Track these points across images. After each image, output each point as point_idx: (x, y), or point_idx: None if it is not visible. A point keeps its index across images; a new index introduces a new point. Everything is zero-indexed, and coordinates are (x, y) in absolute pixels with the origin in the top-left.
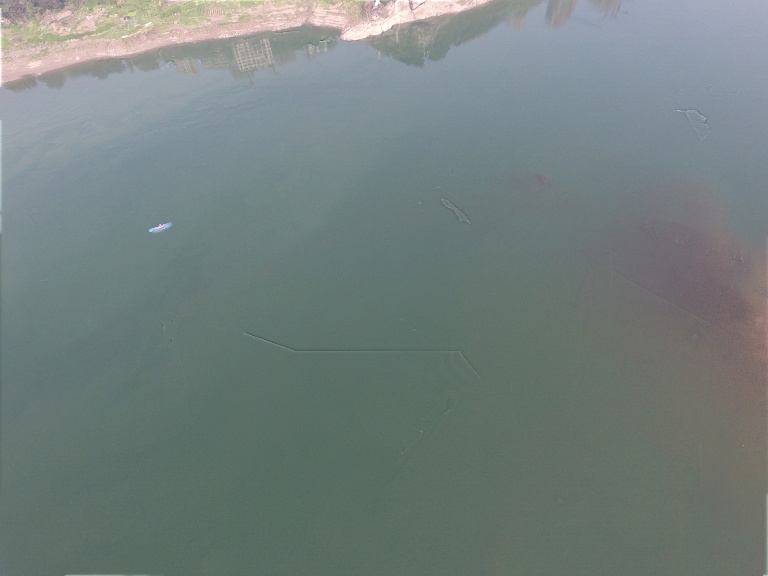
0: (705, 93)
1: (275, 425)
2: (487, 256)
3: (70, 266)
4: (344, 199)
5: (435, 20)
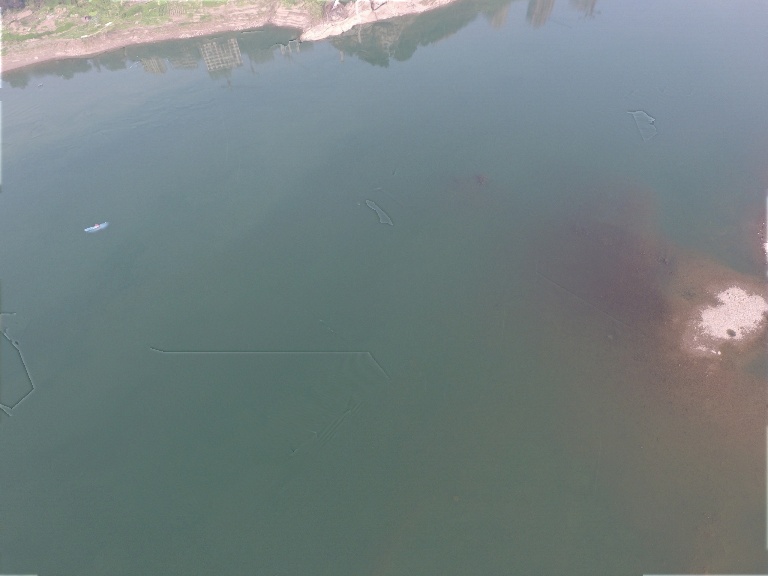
0: (659, 94)
1: (146, 426)
2: (419, 257)
3: (2, 266)
4: (281, 200)
5: (398, 20)
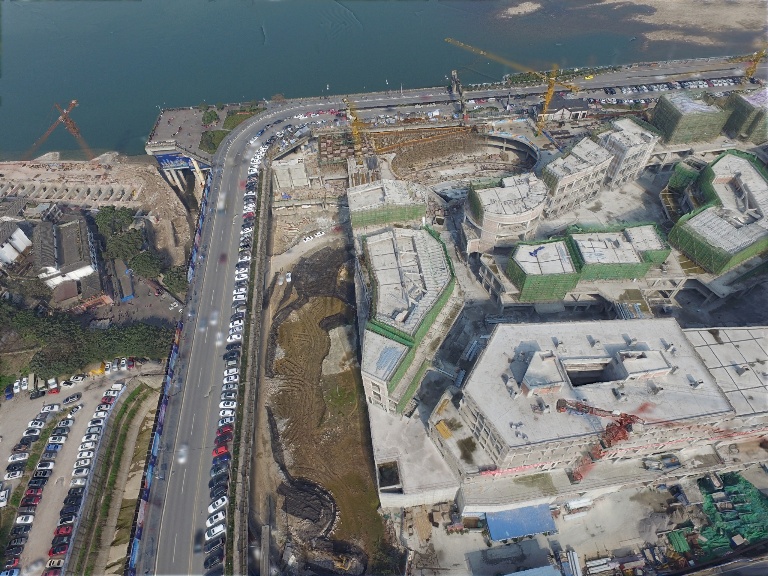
0: None
1: None
2: (380, 7)
3: None
4: None
5: None
